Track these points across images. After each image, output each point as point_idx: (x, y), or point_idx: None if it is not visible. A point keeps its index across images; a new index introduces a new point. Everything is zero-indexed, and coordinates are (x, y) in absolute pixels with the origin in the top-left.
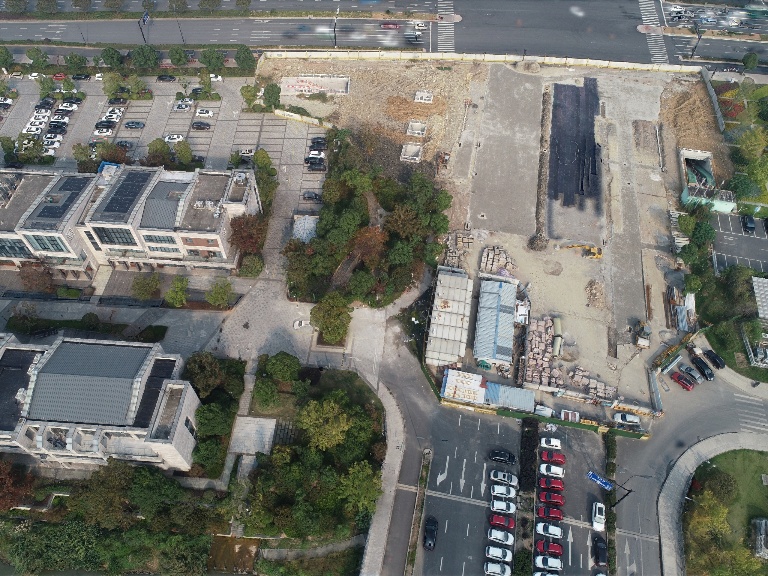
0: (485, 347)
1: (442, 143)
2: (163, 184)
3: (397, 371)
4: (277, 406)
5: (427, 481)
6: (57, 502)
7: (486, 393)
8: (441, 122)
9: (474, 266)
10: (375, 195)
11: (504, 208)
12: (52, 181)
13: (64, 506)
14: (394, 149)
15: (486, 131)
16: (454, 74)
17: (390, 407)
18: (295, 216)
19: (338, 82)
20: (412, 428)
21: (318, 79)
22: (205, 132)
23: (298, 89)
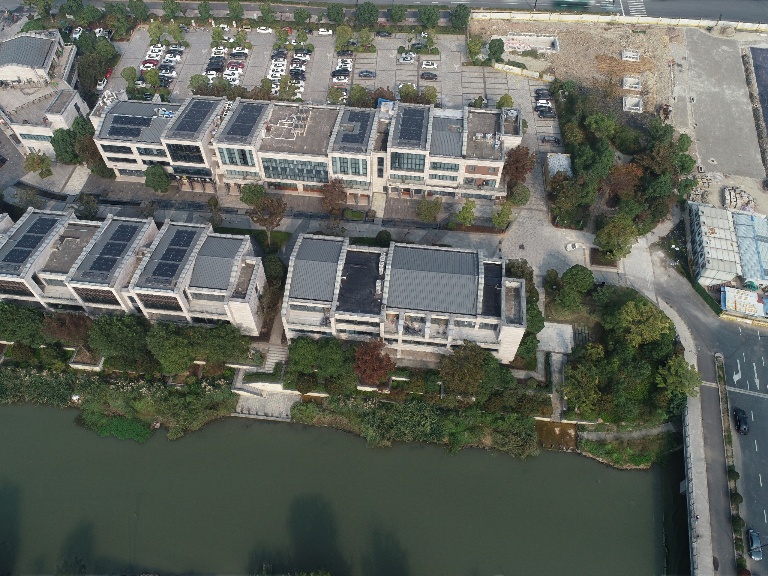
0: (752, 270)
1: (657, 97)
2: (438, 119)
3: (671, 289)
4: (572, 313)
5: (725, 379)
6: (396, 385)
7: (764, 307)
8: (653, 78)
9: (717, 203)
10: (609, 140)
11: (731, 155)
12: (340, 113)
13: (402, 388)
14: (615, 101)
15: (696, 87)
16: (653, 36)
17: (674, 318)
18: (549, 154)
19: (544, 41)
20: (699, 336)
21: (526, 38)
22: (433, 82)
23: (512, 46)
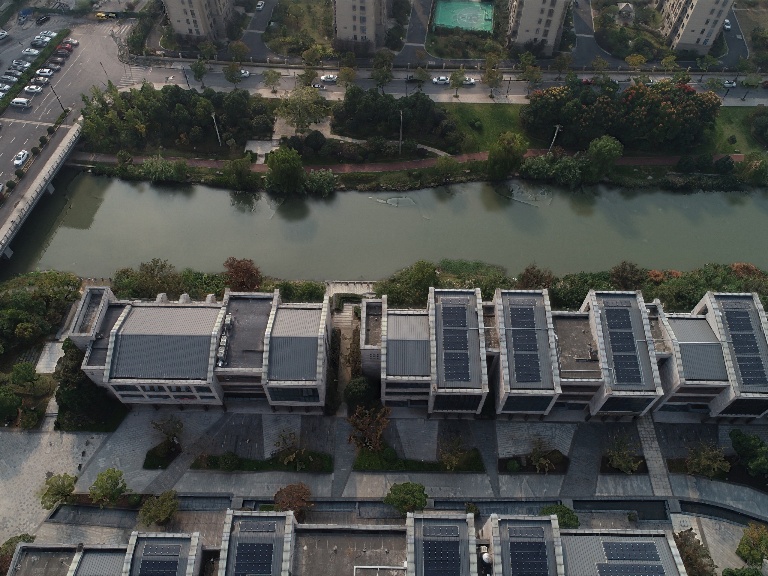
0: None
1: None
2: None
3: None
4: None
5: None
6: None
7: None
8: None
9: None
10: None
11: None
12: None
13: None
14: None
15: None
16: None
17: None
18: None
19: None
20: None
21: None
22: None
23: None
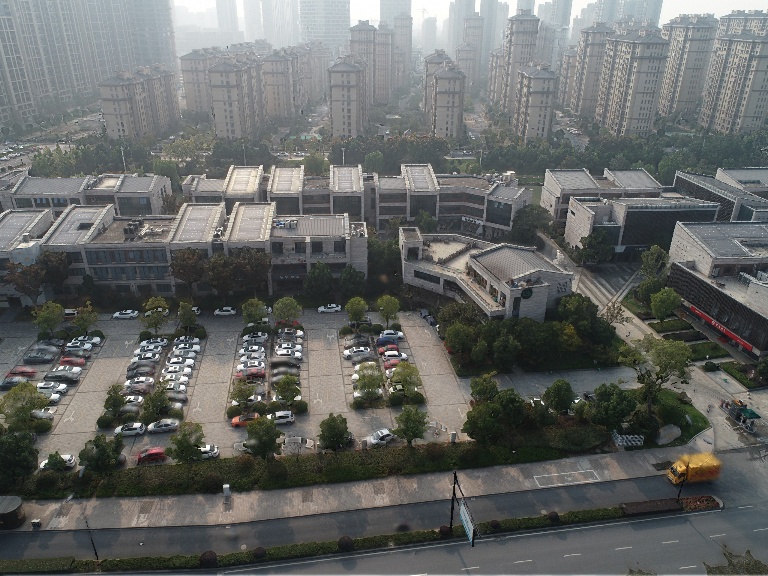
0: None
1: None
2: None
3: None
4: None
5: None
6: None
7: None
8: None
9: None
10: None
11: None
12: (89, 235)
13: None
14: None
15: None
16: None
17: None
18: None
19: None
20: None
21: None
22: None
23: None
